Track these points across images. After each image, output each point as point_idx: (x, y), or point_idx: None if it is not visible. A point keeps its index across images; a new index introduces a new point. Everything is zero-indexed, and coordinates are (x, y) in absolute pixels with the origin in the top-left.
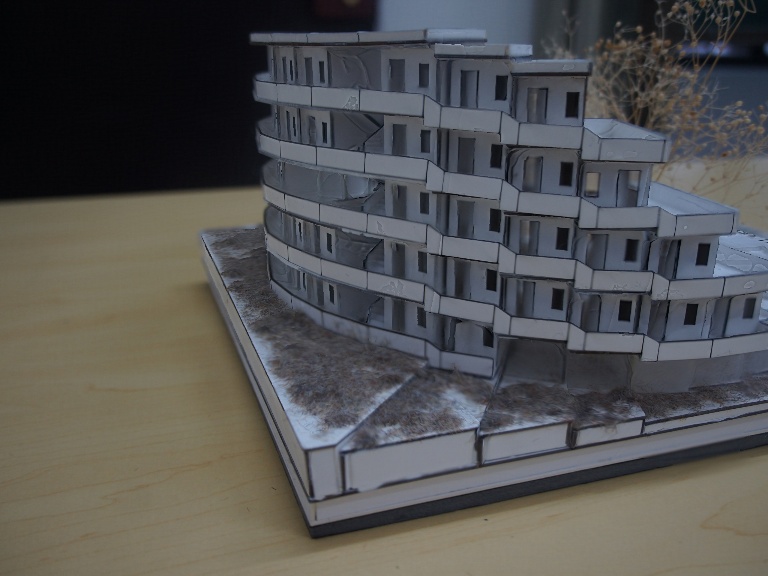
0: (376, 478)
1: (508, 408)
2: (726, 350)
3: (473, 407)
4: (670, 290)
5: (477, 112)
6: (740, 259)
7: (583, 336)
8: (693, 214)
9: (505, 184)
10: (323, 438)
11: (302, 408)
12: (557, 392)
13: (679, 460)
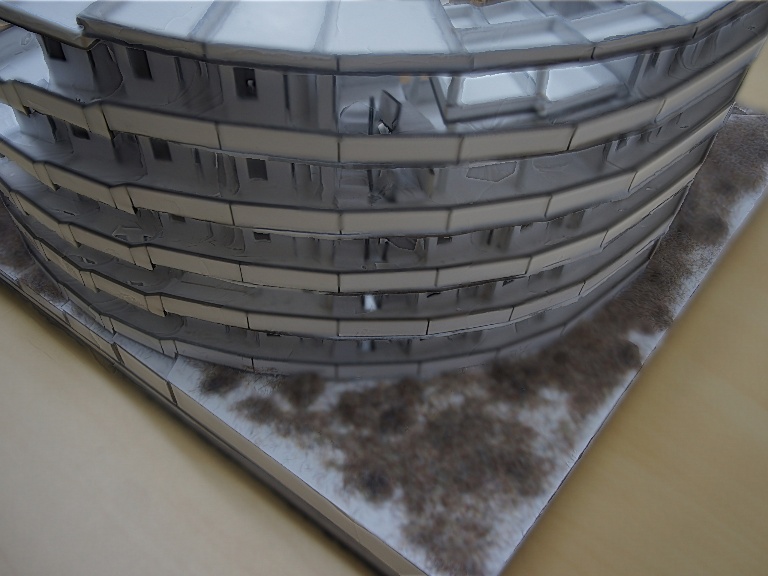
0: None
1: None
2: None
3: None
4: None
5: None
6: None
7: None
8: None
9: None
10: None
11: None
12: None
13: None
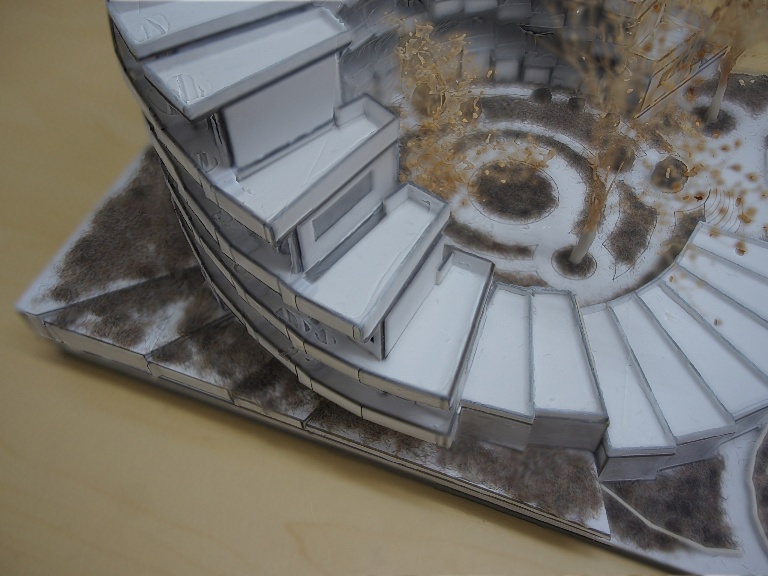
0: (78, 345)
1: (199, 347)
2: (380, 421)
3: (169, 332)
4: (306, 349)
5: (138, 96)
6: None
7: (253, 333)
8: (316, 302)
9: (175, 174)
10: (35, 304)
11: (63, 265)
12: (256, 354)
13: (353, 462)
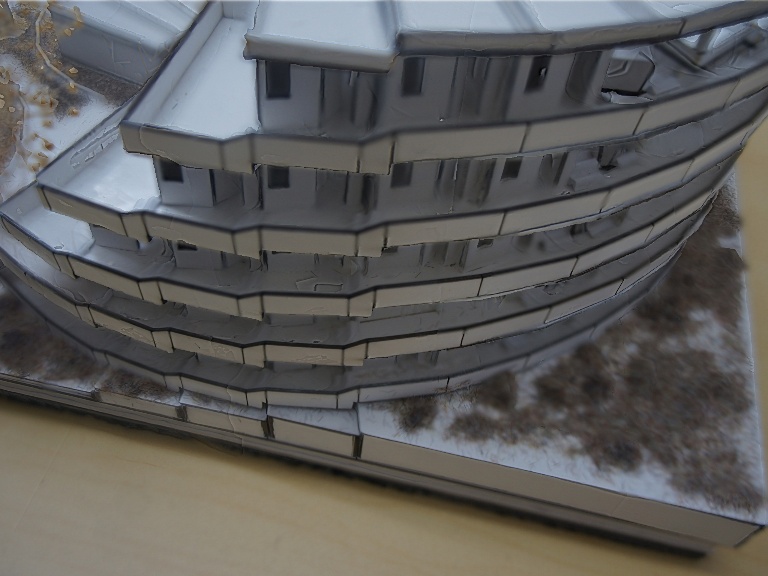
0: None
1: None
2: None
3: None
4: None
5: None
6: (107, 12)
7: None
8: None
9: None
10: None
11: None
12: None
13: None
